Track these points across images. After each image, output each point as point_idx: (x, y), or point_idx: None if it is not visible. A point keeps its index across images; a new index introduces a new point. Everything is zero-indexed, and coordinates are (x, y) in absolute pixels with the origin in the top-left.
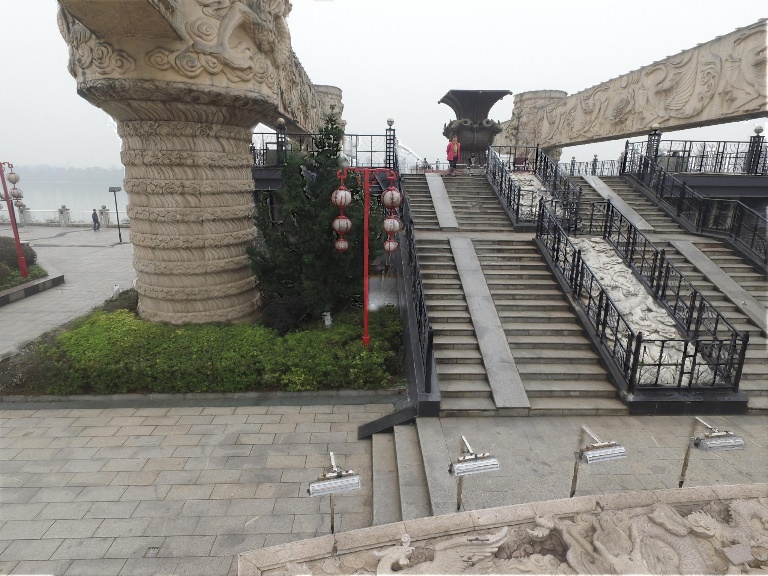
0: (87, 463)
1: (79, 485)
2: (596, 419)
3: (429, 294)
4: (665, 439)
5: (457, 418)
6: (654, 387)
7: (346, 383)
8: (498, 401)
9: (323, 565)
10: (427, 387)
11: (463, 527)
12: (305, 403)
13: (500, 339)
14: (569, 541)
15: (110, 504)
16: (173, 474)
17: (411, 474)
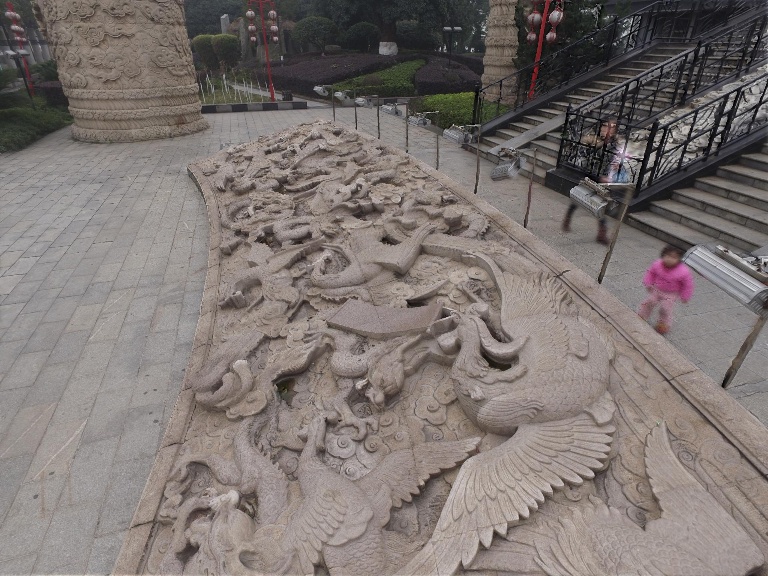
0: None
1: None
2: (521, 177)
3: (583, 90)
4: (516, 190)
5: (471, 153)
6: (572, 167)
7: None
8: None
9: None
10: None
11: None
12: None
13: (560, 122)
14: None
15: None
16: None
17: None
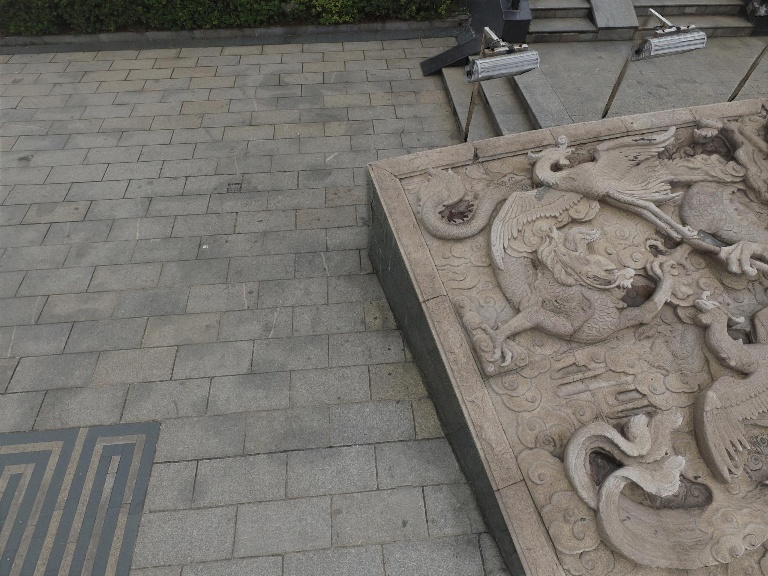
0: (110, 109)
1: (114, 130)
2: (711, 41)
3: None
4: None
5: (547, 43)
6: None
7: (393, 12)
8: (600, 19)
9: (467, 171)
10: (516, 0)
11: (616, 132)
12: (346, 39)
13: None
14: (741, 139)
15: (162, 147)
16: (220, 116)
17: (504, 103)
